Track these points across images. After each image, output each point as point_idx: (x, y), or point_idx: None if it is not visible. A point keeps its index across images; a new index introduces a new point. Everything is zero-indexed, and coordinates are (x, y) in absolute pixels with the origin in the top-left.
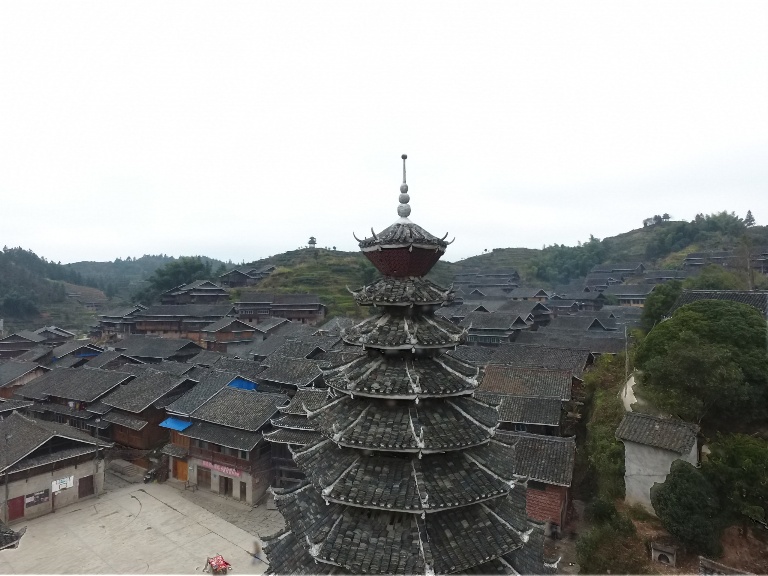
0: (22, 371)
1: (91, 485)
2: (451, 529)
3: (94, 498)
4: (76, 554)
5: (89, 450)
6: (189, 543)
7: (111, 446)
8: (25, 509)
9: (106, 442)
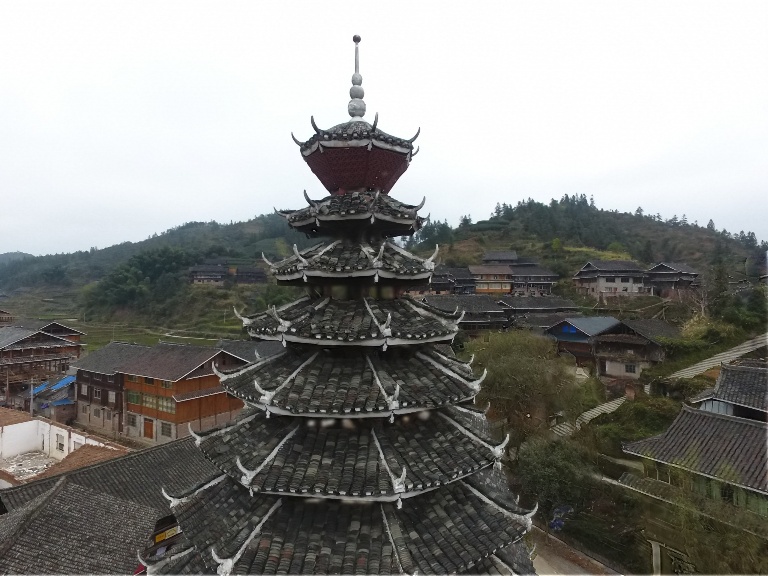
0: None
1: None
2: None
3: None
4: None
5: None
6: None
7: None
8: None
9: None
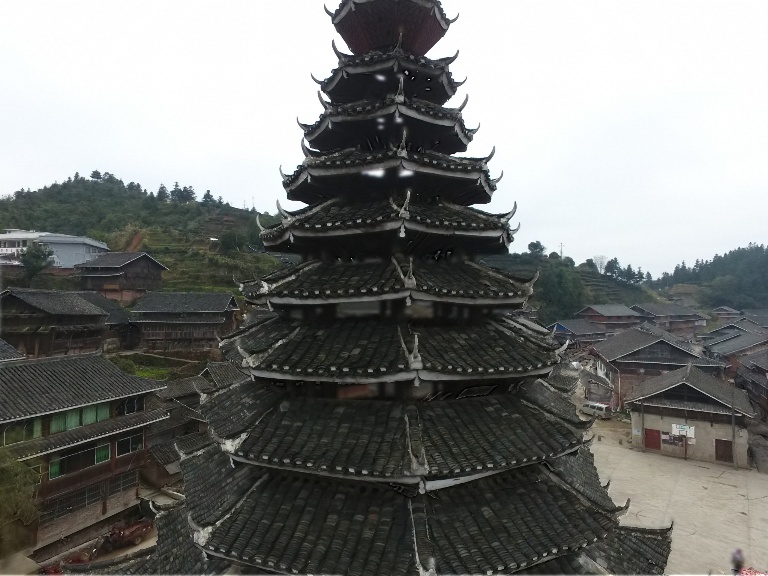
0: (753, 342)
1: (731, 452)
2: (265, 333)
3: (732, 467)
4: (657, 490)
5: (724, 411)
6: (764, 549)
7: (752, 416)
8: (661, 444)
9: (752, 411)
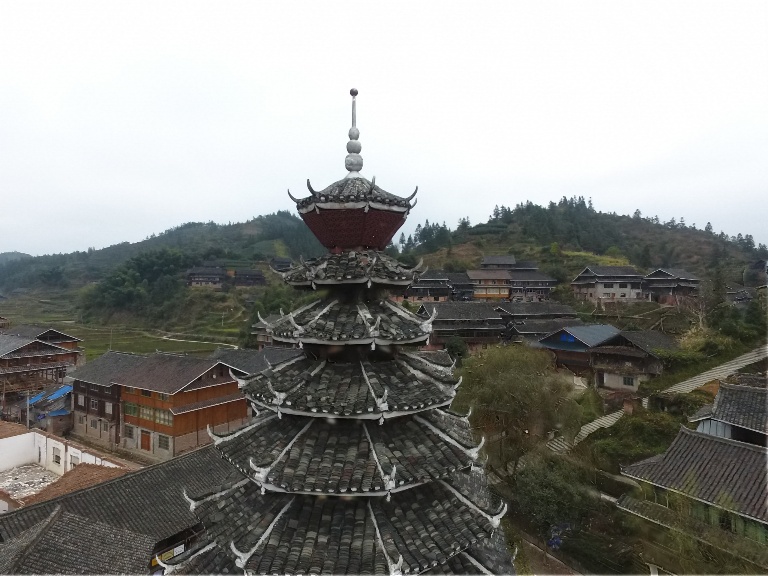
0: None
1: None
2: None
3: None
4: None
5: None
6: None
7: None
8: None
9: None
